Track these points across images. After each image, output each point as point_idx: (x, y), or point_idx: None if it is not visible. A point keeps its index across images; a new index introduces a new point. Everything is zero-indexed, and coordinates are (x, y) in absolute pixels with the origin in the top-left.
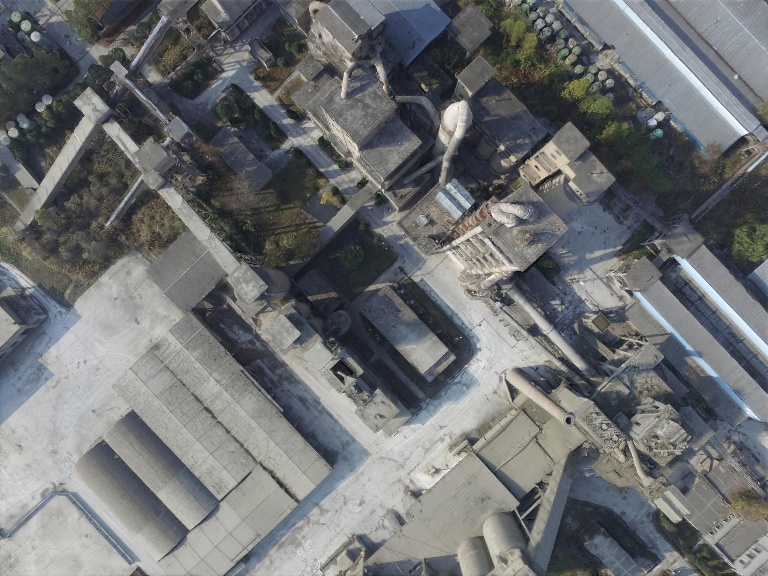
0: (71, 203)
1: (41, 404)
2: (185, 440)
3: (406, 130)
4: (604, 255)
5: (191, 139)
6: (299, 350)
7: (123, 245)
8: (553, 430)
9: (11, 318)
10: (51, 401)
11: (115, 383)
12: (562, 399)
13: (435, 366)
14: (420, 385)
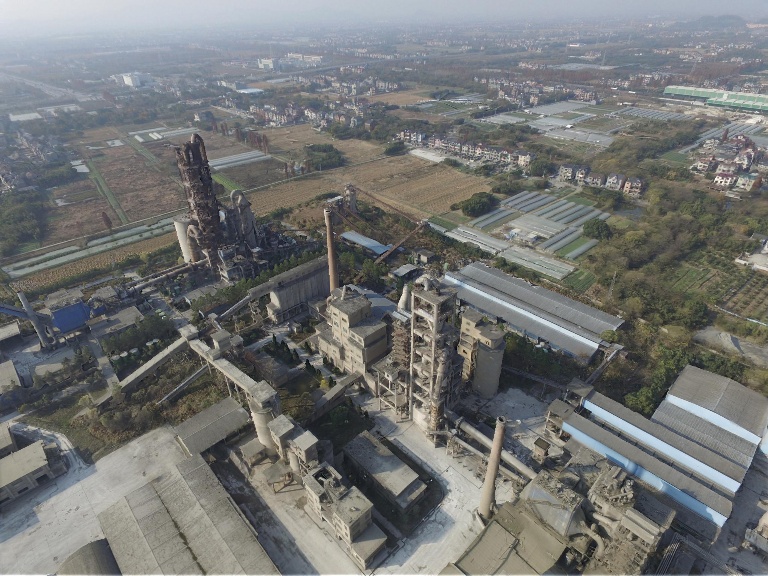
0: (138, 393)
1: (5, 551)
2: (146, 567)
3: (378, 320)
4: (537, 420)
5: (241, 350)
6: (283, 494)
7: (162, 419)
8: (530, 540)
9: (45, 456)
10: (18, 548)
11: (103, 511)
12: (523, 491)
13: (408, 494)
14: (396, 524)
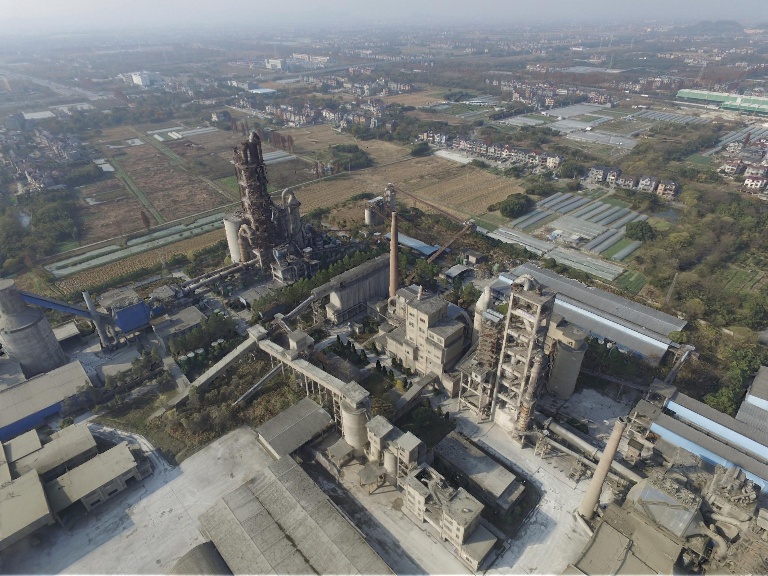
0: (211, 393)
1: (106, 554)
2: (259, 570)
3: (455, 320)
4: None
5: (312, 350)
6: (378, 496)
7: (240, 419)
8: (644, 541)
9: (133, 457)
10: (118, 551)
11: (203, 514)
12: (632, 492)
13: (508, 495)
14: (498, 525)
